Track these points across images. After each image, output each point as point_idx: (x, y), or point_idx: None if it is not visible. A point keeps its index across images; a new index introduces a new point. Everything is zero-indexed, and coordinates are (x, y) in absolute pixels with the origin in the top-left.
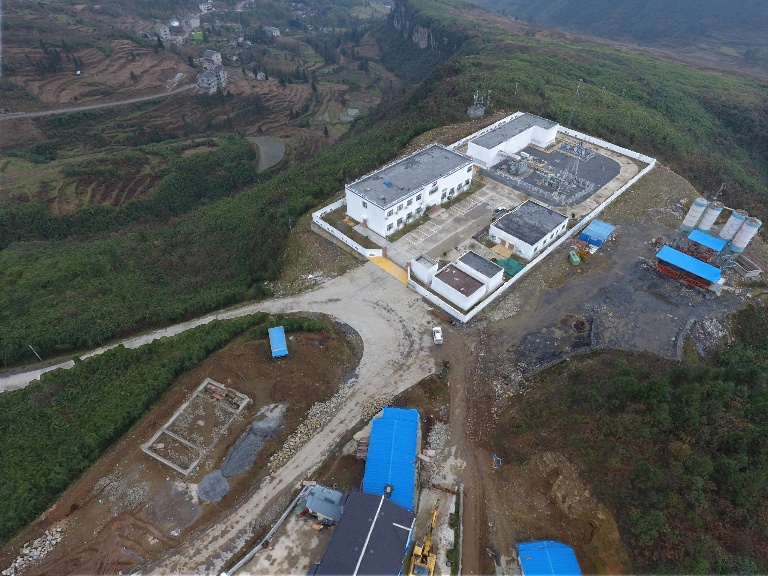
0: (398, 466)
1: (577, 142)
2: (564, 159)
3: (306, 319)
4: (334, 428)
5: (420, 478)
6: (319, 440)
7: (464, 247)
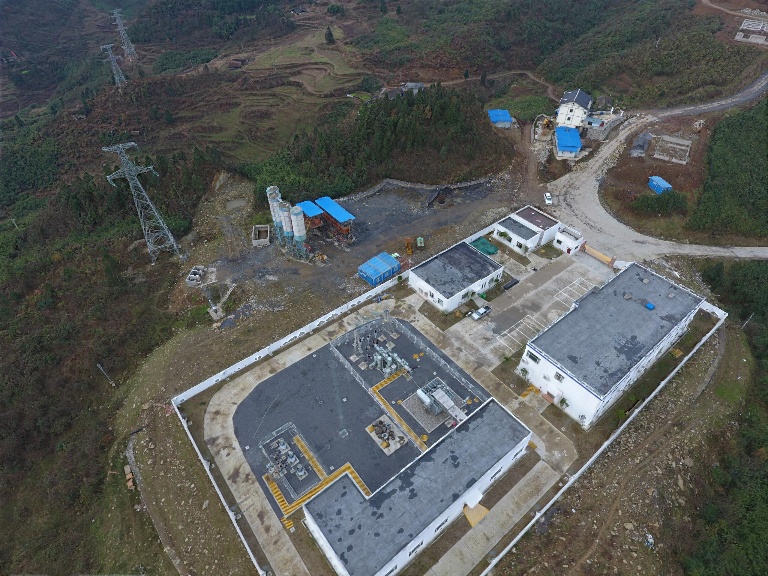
0: (565, 135)
1: (258, 510)
2: (328, 438)
3: (651, 199)
4: (600, 159)
5: (552, 141)
6: (606, 154)
7: (527, 271)
